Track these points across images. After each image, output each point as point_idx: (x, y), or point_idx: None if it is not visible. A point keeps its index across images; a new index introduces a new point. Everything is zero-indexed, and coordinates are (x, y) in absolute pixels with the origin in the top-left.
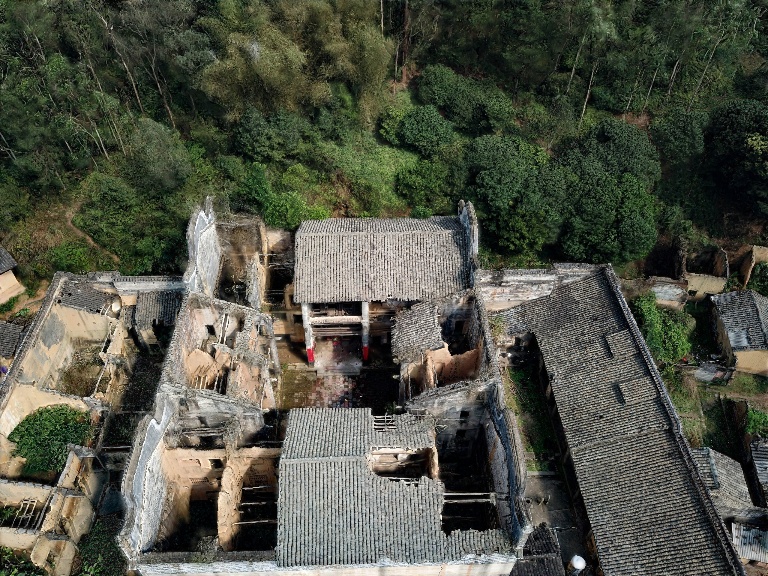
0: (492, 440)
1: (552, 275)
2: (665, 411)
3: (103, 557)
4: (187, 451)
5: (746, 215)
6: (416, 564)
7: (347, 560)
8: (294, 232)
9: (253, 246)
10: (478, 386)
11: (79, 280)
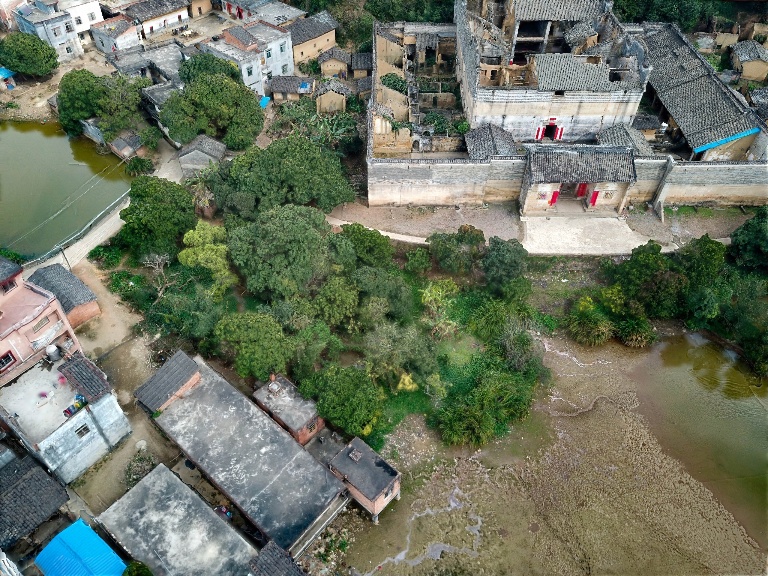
0: (624, 67)
1: (642, 27)
2: (706, 68)
3: (437, 121)
4: (483, 64)
5: (751, 12)
6: (596, 100)
7: (570, 88)
8: (500, 3)
9: (475, 13)
10: (619, 38)
11: (384, 27)
